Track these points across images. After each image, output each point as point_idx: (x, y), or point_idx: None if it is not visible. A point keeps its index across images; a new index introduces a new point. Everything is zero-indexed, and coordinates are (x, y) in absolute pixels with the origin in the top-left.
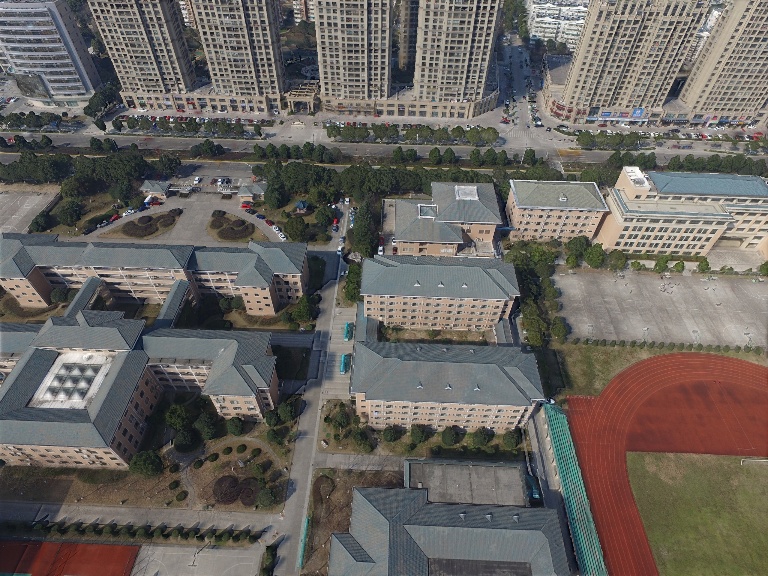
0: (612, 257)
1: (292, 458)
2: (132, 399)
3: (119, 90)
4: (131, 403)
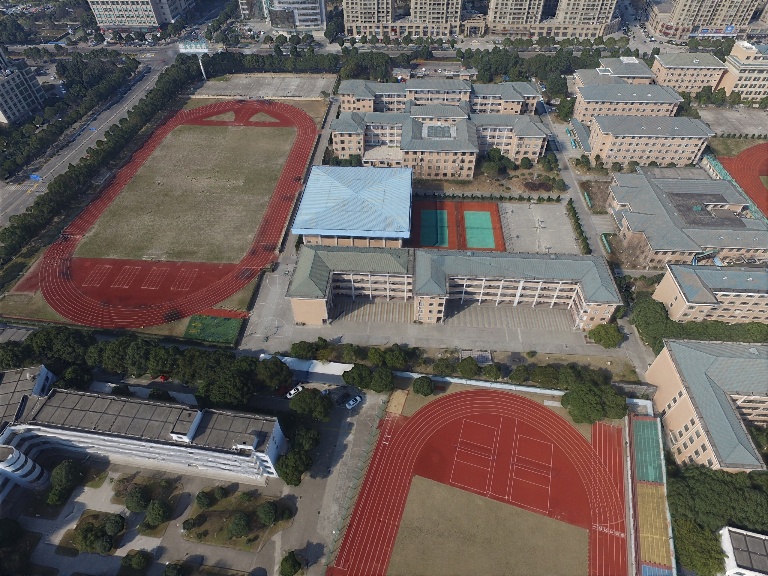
0: (732, 96)
1: (562, 177)
2: None
3: (340, 23)
4: None
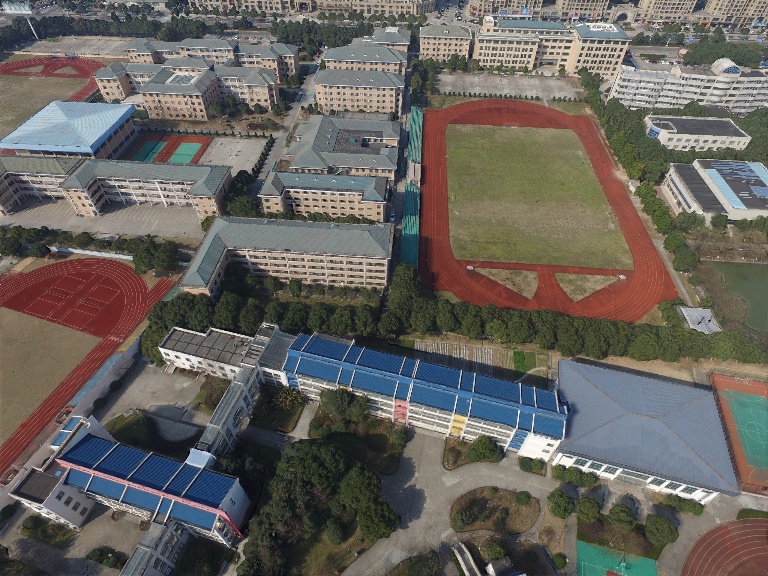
0: (471, 62)
1: (284, 121)
2: (210, 88)
3: None
4: (209, 89)
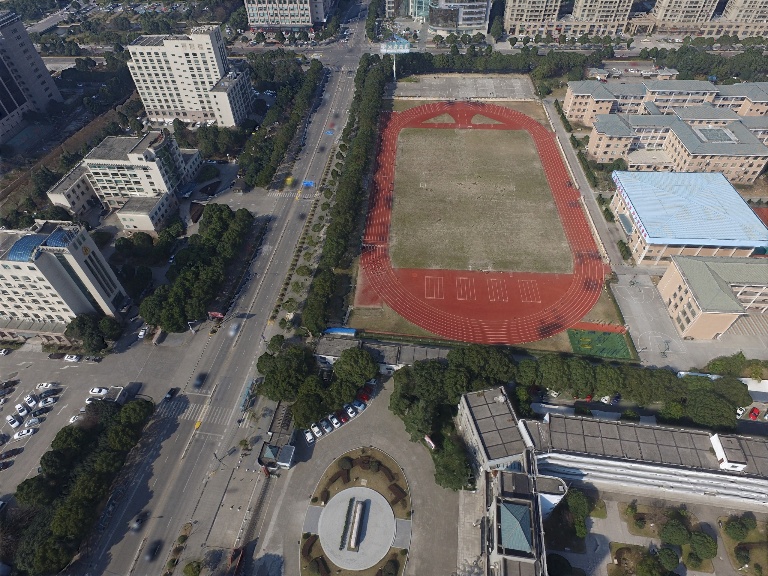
0: None
1: None
2: None
3: (501, 22)
4: None
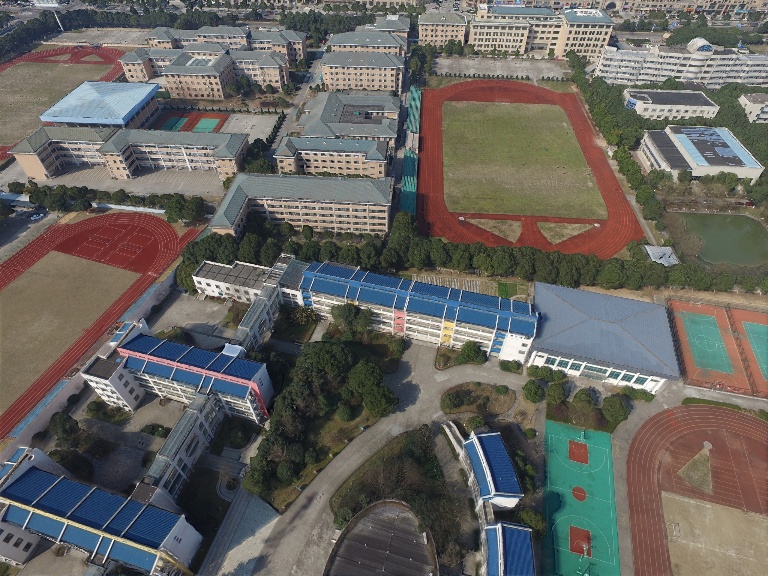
0: (466, 46)
1: (294, 99)
2: None
3: None
4: (225, 71)
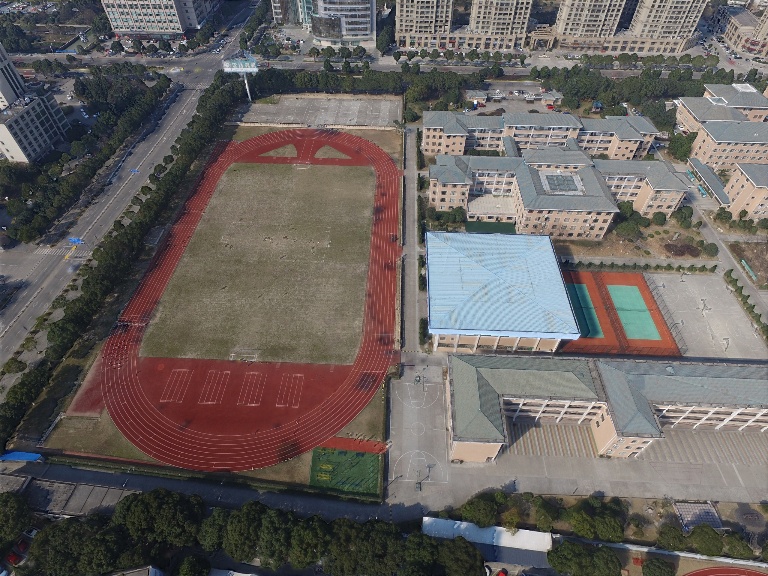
0: None
1: (704, 237)
2: None
3: (391, 32)
4: None
